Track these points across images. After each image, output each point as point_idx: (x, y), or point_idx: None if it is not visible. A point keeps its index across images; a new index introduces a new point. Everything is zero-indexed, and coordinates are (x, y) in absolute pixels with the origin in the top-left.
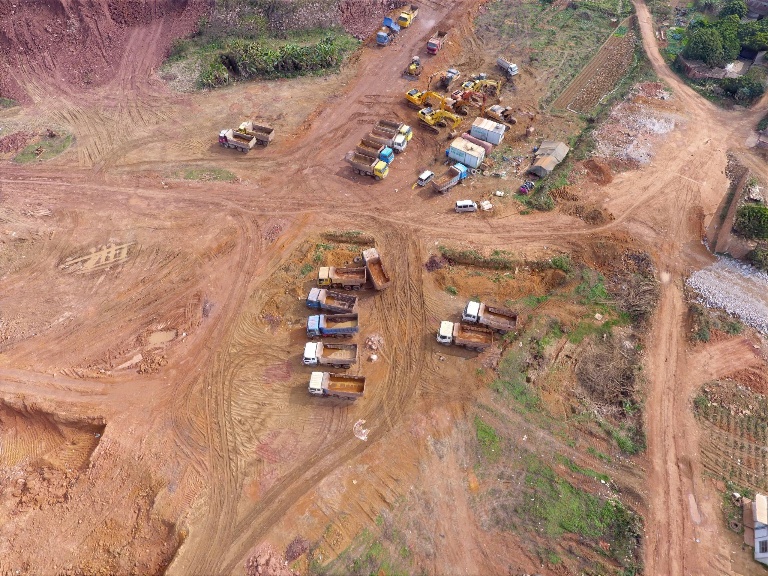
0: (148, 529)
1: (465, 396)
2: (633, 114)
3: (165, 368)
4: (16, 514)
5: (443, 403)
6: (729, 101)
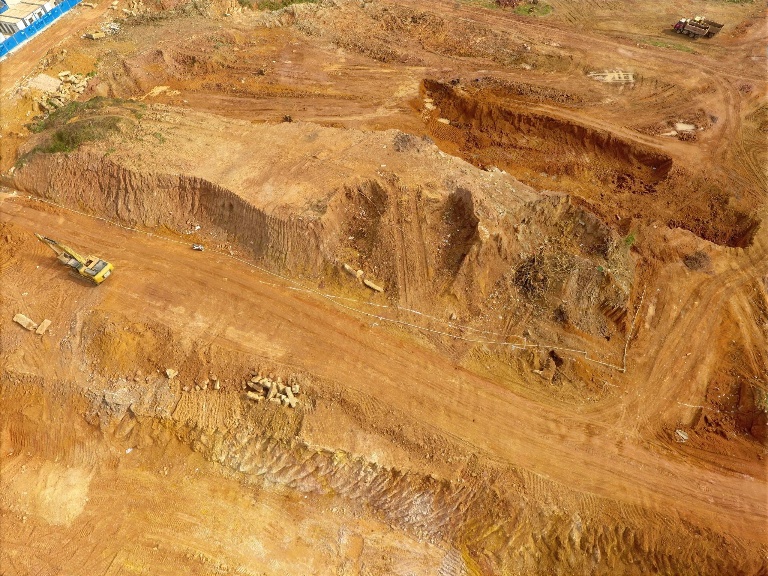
0: (723, 216)
1: None
2: None
3: (698, 141)
4: (616, 192)
5: None
6: None
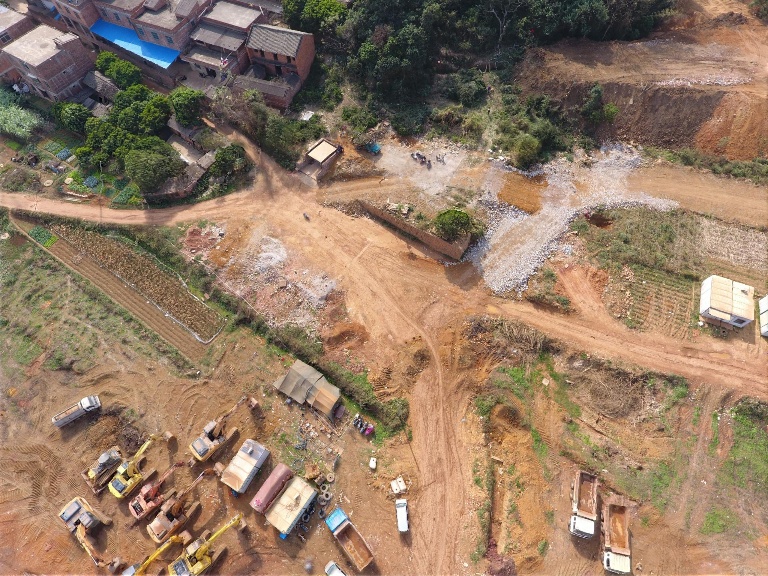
0: None
1: (679, 542)
2: (245, 273)
3: None
4: None
5: (692, 569)
6: (242, 177)
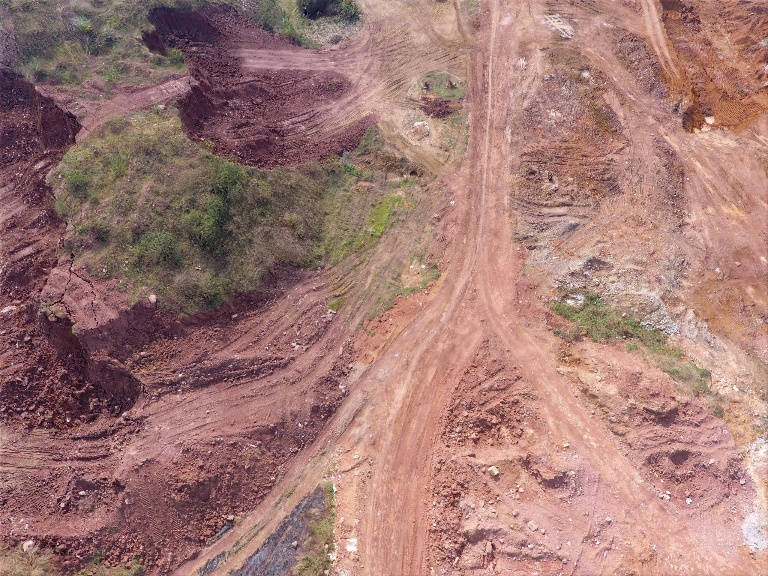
0: None
1: None
2: None
3: None
4: None
5: None
6: None
